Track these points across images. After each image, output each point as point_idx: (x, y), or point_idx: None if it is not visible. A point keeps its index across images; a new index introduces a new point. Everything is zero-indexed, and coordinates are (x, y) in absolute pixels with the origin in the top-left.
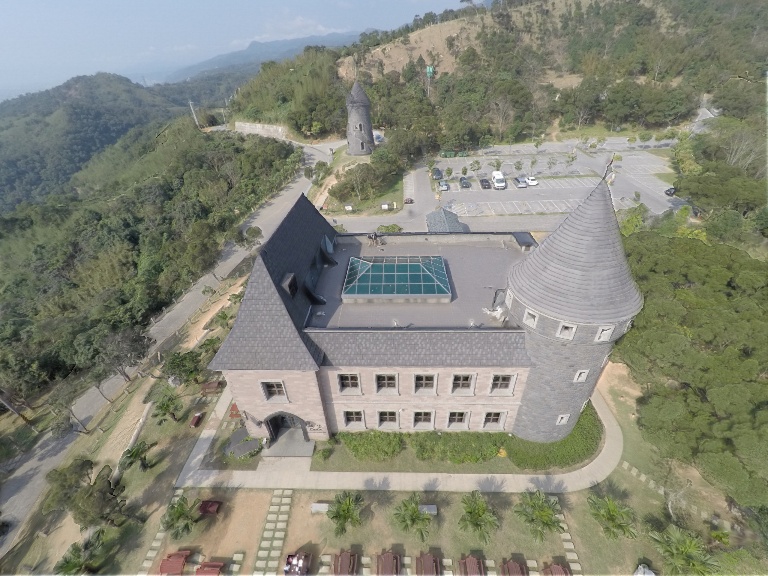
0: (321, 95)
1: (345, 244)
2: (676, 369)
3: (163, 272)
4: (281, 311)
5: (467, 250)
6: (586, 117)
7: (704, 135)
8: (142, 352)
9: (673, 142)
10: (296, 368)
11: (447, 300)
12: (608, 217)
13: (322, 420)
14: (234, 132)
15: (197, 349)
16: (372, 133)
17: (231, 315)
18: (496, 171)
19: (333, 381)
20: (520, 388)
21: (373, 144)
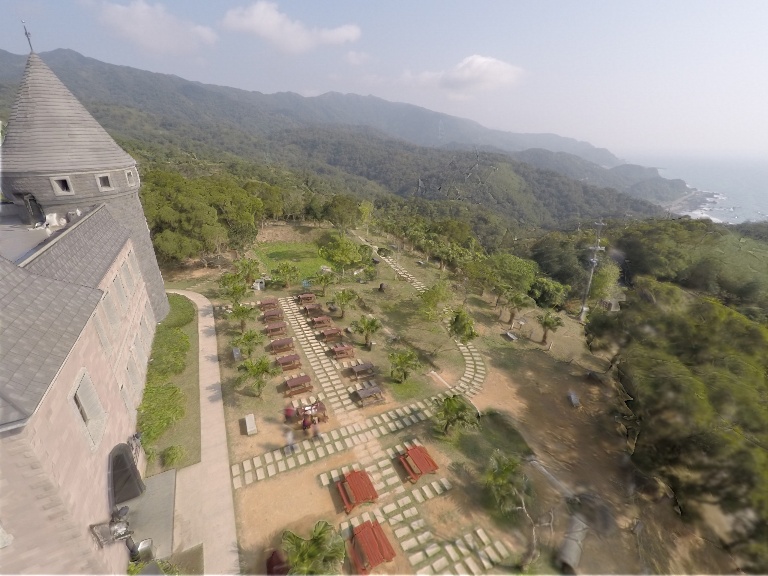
0: None
1: None
2: None
3: None
4: None
5: None
6: None
7: None
8: None
9: None
10: (92, 305)
11: None
12: None
13: (130, 422)
14: None
15: None
16: None
17: None
18: None
19: None
20: (137, 265)
21: None
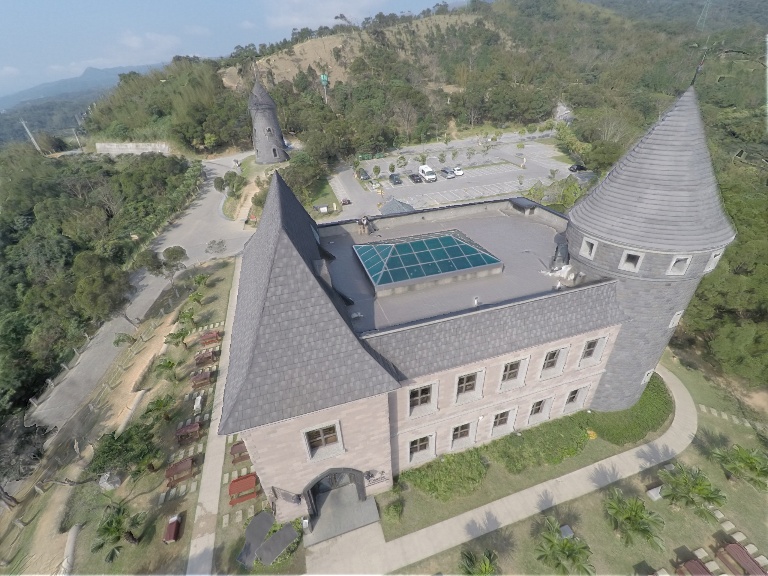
0: (208, 106)
1: (329, 237)
2: (721, 297)
3: (34, 332)
4: (328, 313)
5: (471, 222)
6: (477, 117)
7: (578, 122)
8: (36, 451)
9: (552, 132)
10: (367, 394)
11: (499, 270)
12: (703, 126)
13: (387, 463)
14: (97, 154)
15: (133, 422)
16: (282, 139)
17: (178, 361)
18: (422, 165)
19: (402, 402)
20: (607, 351)
21: (289, 148)
